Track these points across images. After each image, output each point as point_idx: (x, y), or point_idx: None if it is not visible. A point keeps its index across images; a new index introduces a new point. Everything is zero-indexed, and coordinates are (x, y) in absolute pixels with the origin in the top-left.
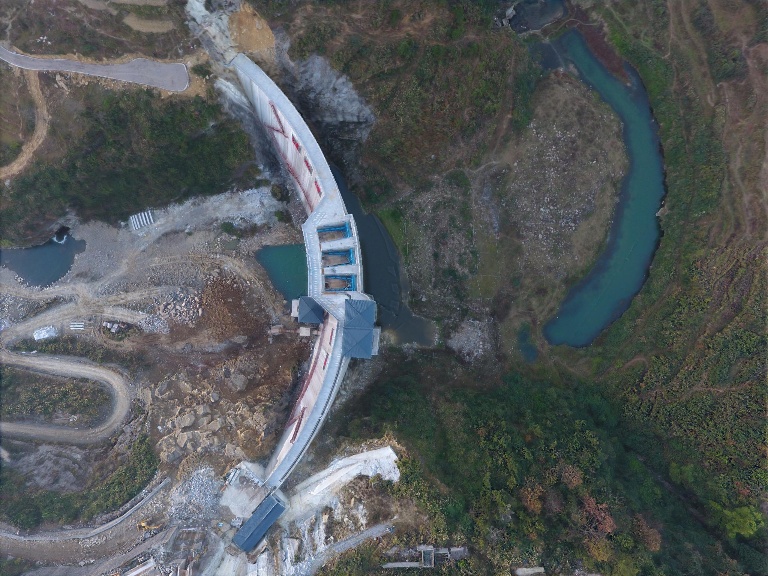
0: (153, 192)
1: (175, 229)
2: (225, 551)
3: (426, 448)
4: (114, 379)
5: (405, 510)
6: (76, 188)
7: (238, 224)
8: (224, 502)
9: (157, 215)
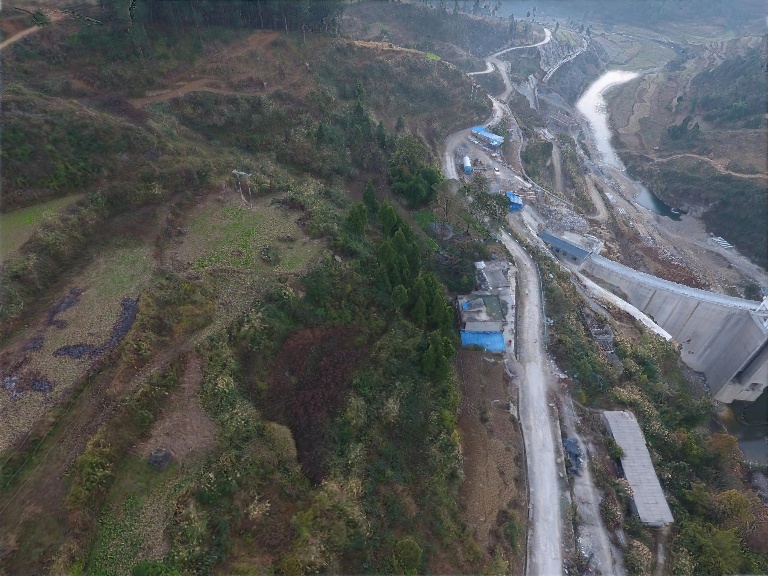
0: (759, 241)
1: (728, 259)
2: (540, 223)
3: (674, 382)
4: (603, 216)
5: (629, 330)
6: (741, 199)
7: (763, 293)
8: (567, 233)
9: (732, 251)
